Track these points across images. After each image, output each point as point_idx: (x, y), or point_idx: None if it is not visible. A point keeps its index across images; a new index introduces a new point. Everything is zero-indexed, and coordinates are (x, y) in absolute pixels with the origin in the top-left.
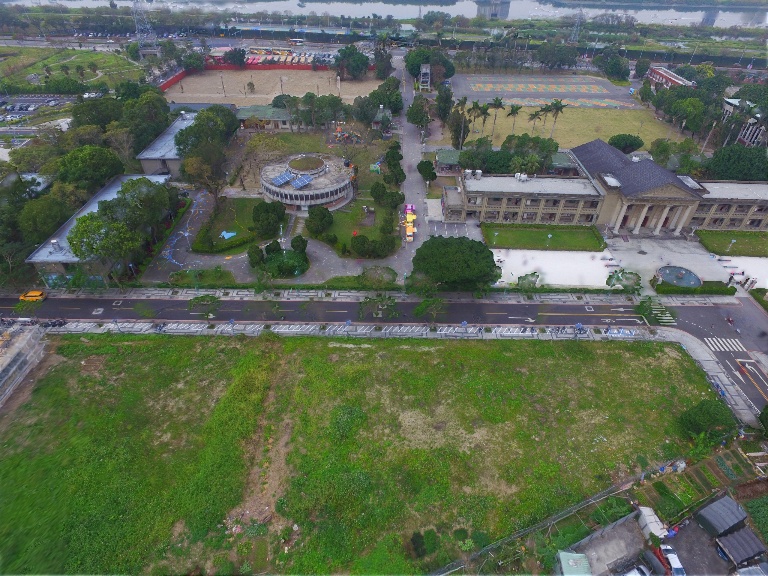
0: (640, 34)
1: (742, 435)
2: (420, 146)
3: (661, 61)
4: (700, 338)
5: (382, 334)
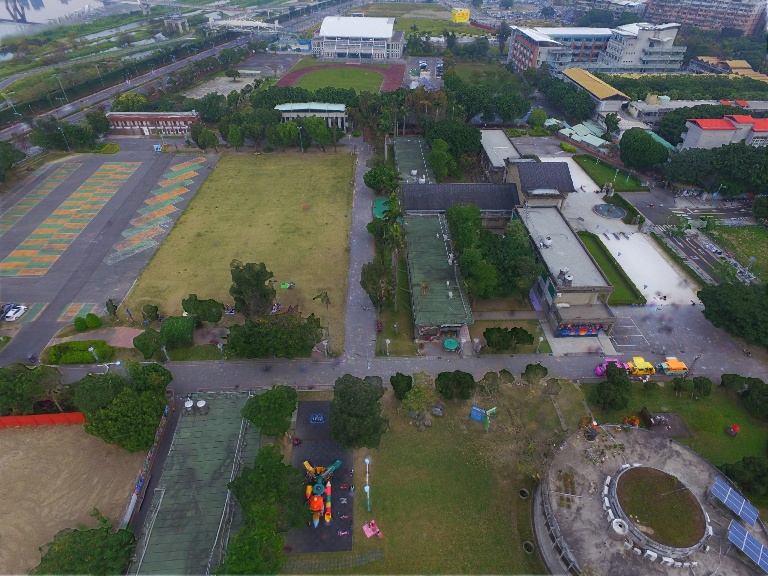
0: None
1: None
2: (351, 358)
3: (42, 111)
4: None
5: None
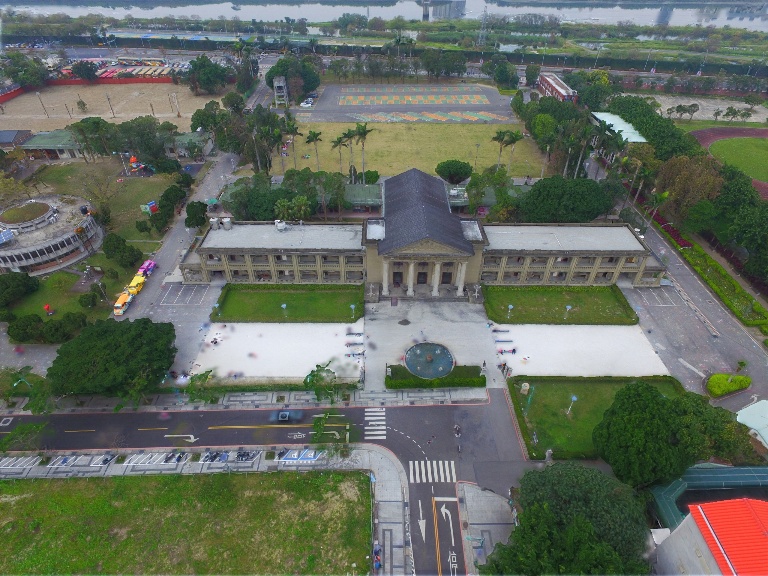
0: (561, 35)
1: None
2: (228, 177)
3: (565, 65)
4: (404, 461)
5: None
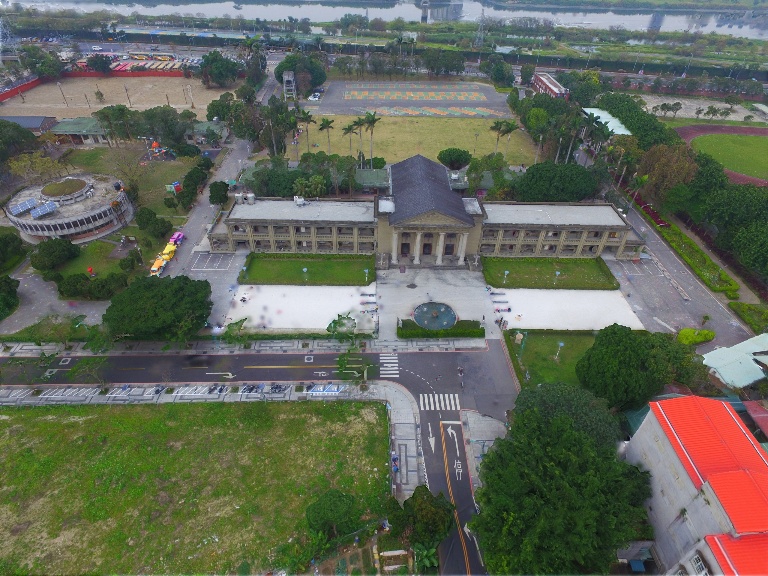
0: (555, 38)
1: (387, 527)
2: (244, 162)
3: (558, 66)
4: (415, 394)
5: (36, 400)
